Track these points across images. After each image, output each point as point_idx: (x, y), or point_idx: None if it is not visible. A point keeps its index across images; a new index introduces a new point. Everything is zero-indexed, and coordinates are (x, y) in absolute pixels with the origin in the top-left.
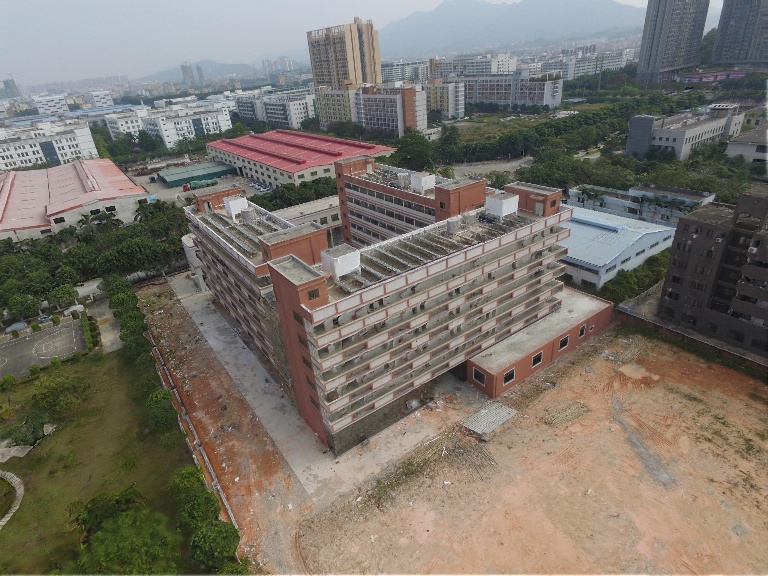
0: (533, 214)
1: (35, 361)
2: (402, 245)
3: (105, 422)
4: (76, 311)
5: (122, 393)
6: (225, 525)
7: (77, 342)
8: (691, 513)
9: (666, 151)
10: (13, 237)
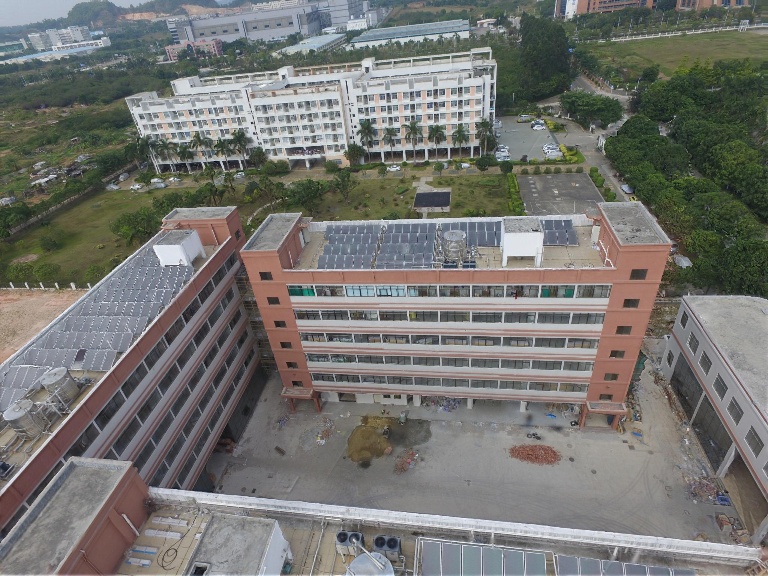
0: None
1: None
2: None
3: None
4: None
5: None
6: None
7: None
8: None
9: None
10: None
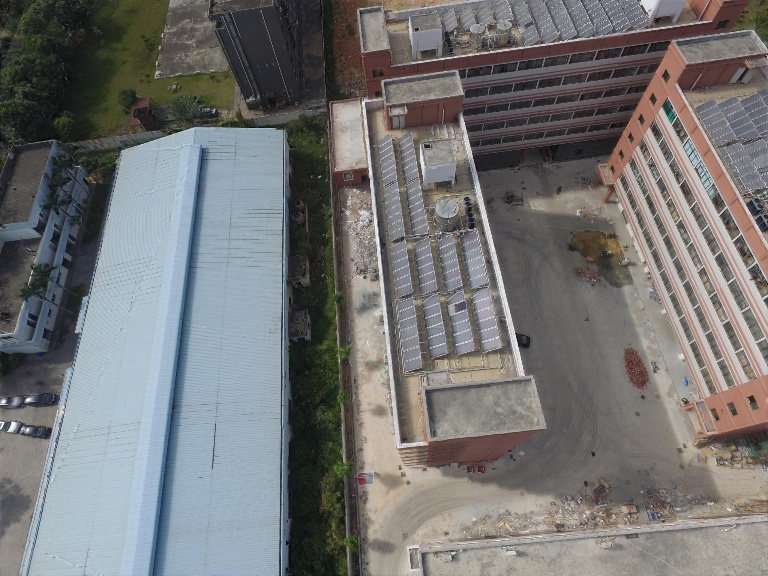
0: None
1: None
2: None
3: None
4: None
5: None
6: None
7: None
8: None
9: None
10: None
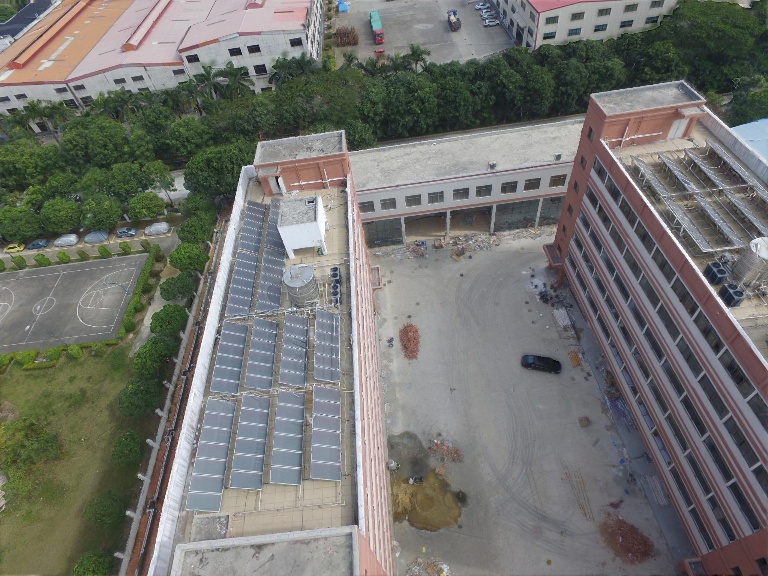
0: None
1: (71, 324)
2: None
3: (51, 533)
4: (147, 242)
5: (100, 471)
6: None
7: (122, 307)
8: None
9: None
10: (144, 75)
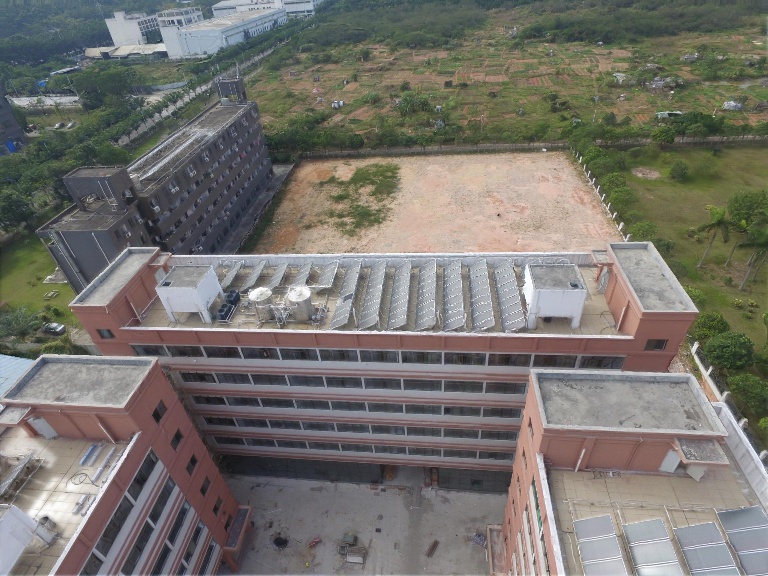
0: None
1: None
2: (409, 320)
3: None
4: None
5: None
6: (721, 343)
7: None
8: None
9: None
10: None
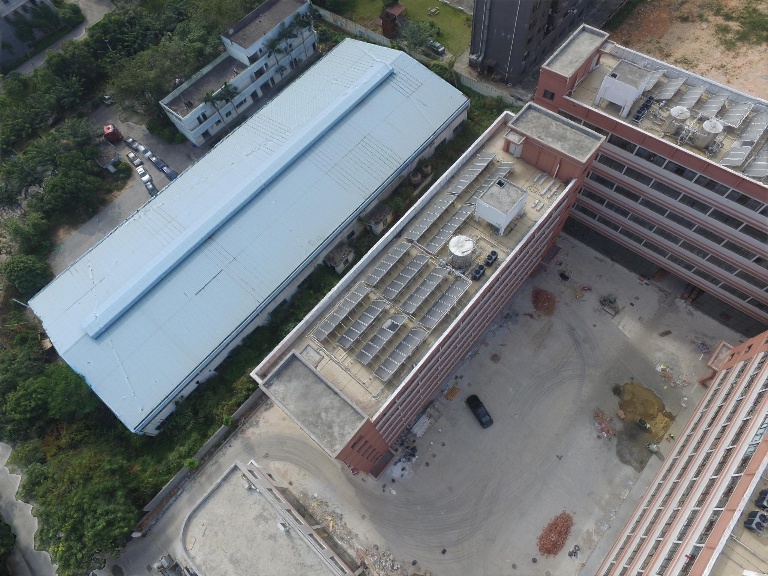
0: (591, 73)
1: None
2: None
3: None
4: None
5: None
6: None
7: None
8: (767, 94)
9: (37, 11)
10: None
